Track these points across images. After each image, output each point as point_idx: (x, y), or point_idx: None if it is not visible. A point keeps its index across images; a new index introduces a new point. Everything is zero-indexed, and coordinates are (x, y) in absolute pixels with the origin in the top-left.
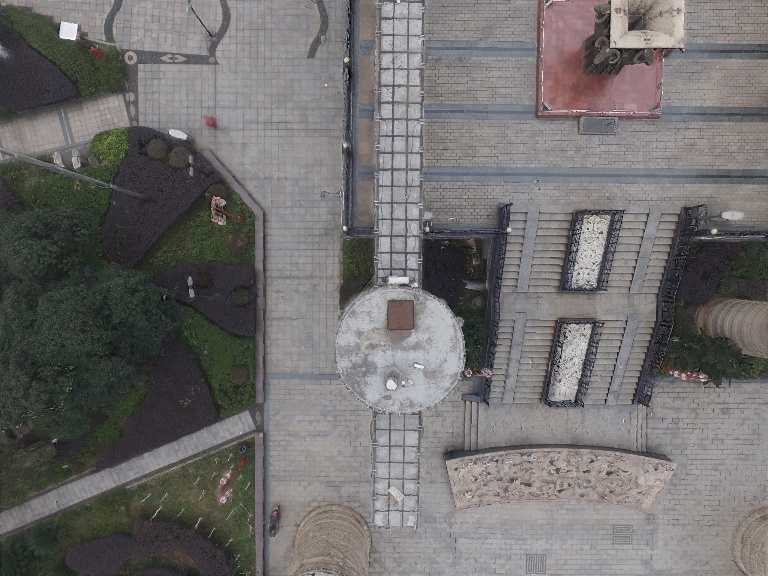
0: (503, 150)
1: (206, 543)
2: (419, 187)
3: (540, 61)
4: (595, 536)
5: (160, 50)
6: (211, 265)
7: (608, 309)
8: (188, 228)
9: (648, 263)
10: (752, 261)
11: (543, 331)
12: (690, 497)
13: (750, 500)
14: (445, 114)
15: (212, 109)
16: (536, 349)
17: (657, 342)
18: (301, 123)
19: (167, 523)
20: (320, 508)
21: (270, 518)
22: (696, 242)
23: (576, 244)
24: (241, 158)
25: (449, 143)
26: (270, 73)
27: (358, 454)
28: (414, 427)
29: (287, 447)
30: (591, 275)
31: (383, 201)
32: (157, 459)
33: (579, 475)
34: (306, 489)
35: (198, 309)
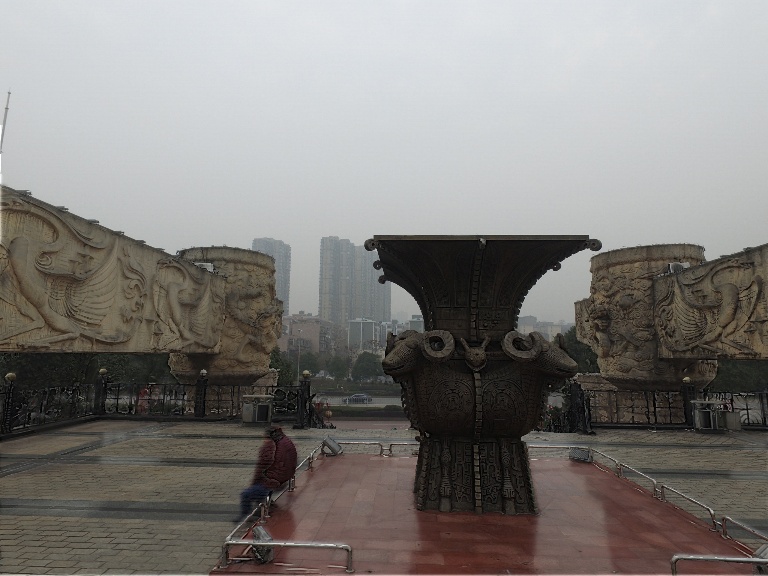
0: None
1: None
2: None
3: None
4: None
5: None
6: None
7: None
8: None
9: None
10: None
11: None
12: None
13: None
14: None
15: None
16: None
17: None
18: None
19: None
20: None
21: None
22: None
23: None
24: None
25: None
26: None
27: None
28: None
29: None
30: None
31: None
32: None
33: None
34: None
35: None
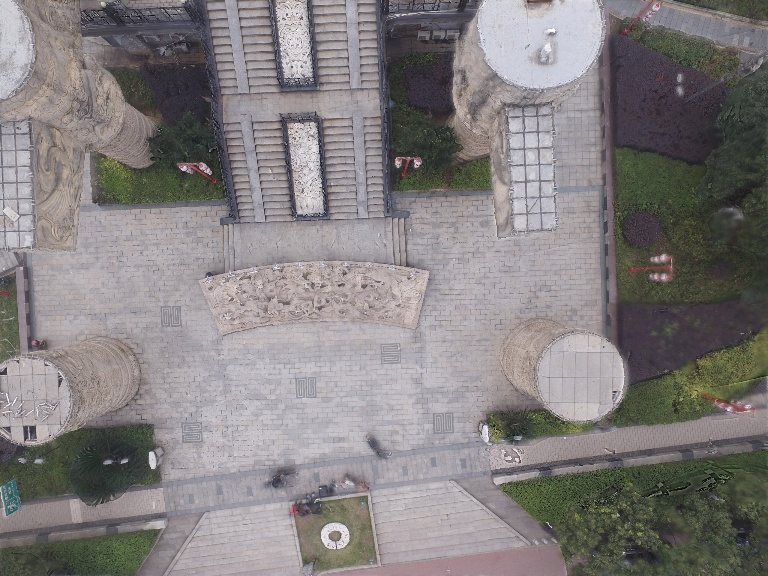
0: None
1: None
2: None
3: None
4: (363, 356)
5: None
6: None
7: (332, 107)
8: None
9: (360, 53)
10: None
11: (272, 134)
12: (455, 312)
13: (516, 312)
14: None
15: None
16: (272, 156)
17: None
18: None
19: None
20: (86, 340)
21: None
22: (442, 55)
23: (272, 27)
24: None
25: None
26: None
27: (122, 285)
28: (25, 147)
29: (51, 281)
30: (304, 68)
31: None
32: None
33: (334, 289)
34: (72, 323)
35: None
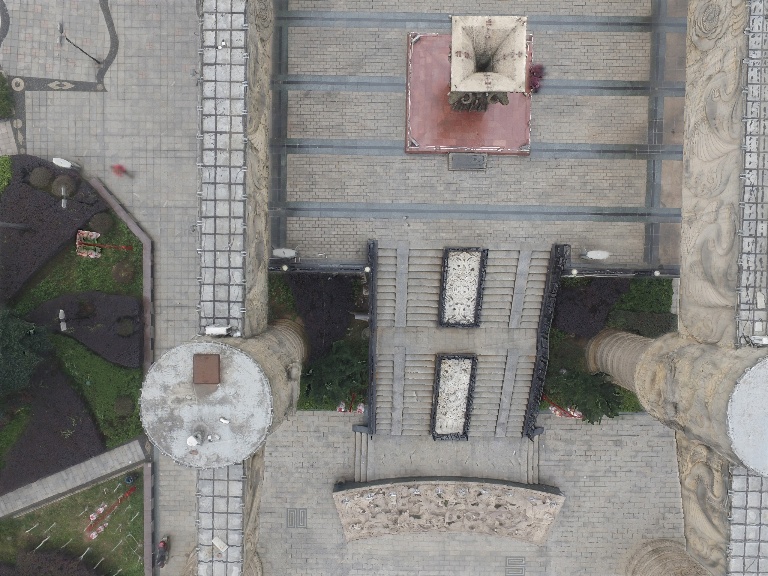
0: (372, 186)
1: (90, 574)
2: (242, 235)
3: (408, 97)
4: (487, 568)
5: (47, 77)
6: (94, 295)
7: (488, 344)
8: (73, 257)
9: (524, 299)
10: (642, 294)
11: (424, 365)
12: (583, 529)
13: (643, 532)
14: (314, 149)
15: (100, 137)
16: (419, 382)
17: (538, 377)
18: (190, 151)
19: (51, 554)
20: None
21: (158, 549)
22: None
23: (445, 281)
24: (130, 186)
25: (318, 178)
26: (159, 101)
27: None
28: (238, 477)
29: (177, 477)
30: (467, 311)
31: (206, 249)
32: (45, 488)
33: (467, 508)
34: None
35: (79, 340)
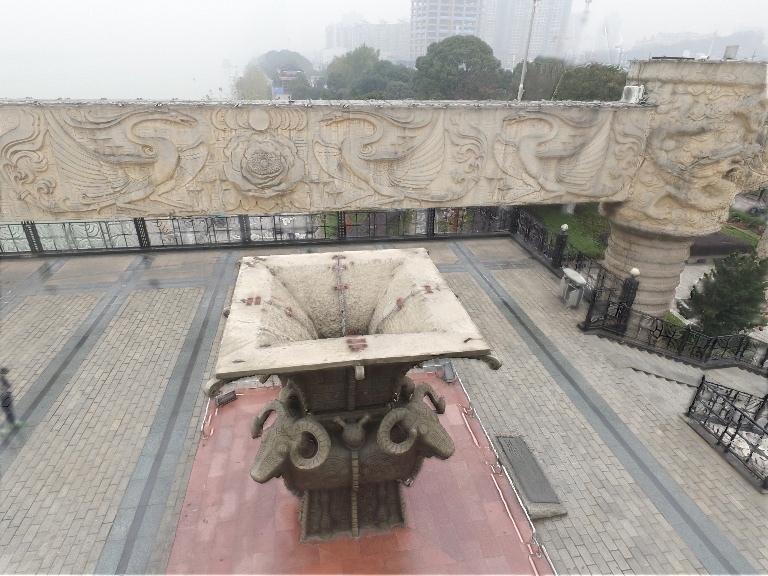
0: None
1: None
2: None
3: None
4: None
5: None
6: None
7: None
8: None
9: None
10: None
11: None
12: None
13: None
14: None
15: None
16: None
17: (762, 364)
18: None
19: None
20: None
21: None
22: None
23: None
24: None
25: None
26: None
27: None
28: None
29: None
30: None
31: None
32: None
33: None
34: None
35: None
